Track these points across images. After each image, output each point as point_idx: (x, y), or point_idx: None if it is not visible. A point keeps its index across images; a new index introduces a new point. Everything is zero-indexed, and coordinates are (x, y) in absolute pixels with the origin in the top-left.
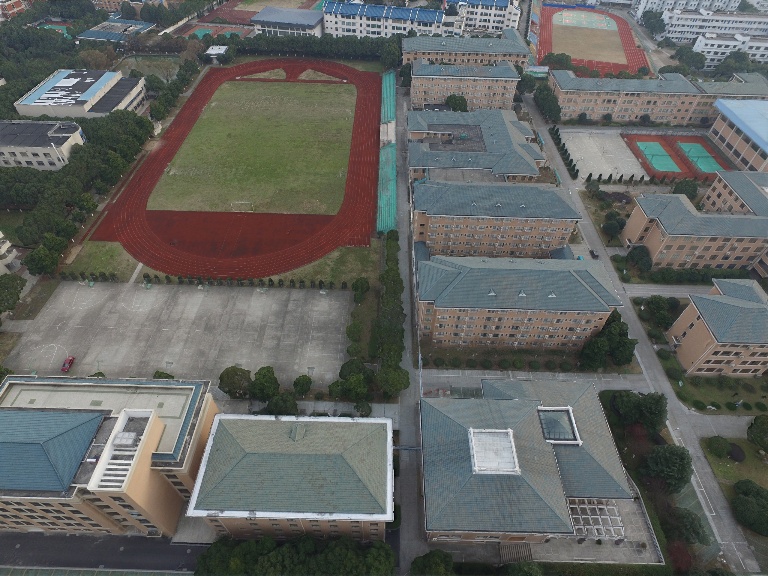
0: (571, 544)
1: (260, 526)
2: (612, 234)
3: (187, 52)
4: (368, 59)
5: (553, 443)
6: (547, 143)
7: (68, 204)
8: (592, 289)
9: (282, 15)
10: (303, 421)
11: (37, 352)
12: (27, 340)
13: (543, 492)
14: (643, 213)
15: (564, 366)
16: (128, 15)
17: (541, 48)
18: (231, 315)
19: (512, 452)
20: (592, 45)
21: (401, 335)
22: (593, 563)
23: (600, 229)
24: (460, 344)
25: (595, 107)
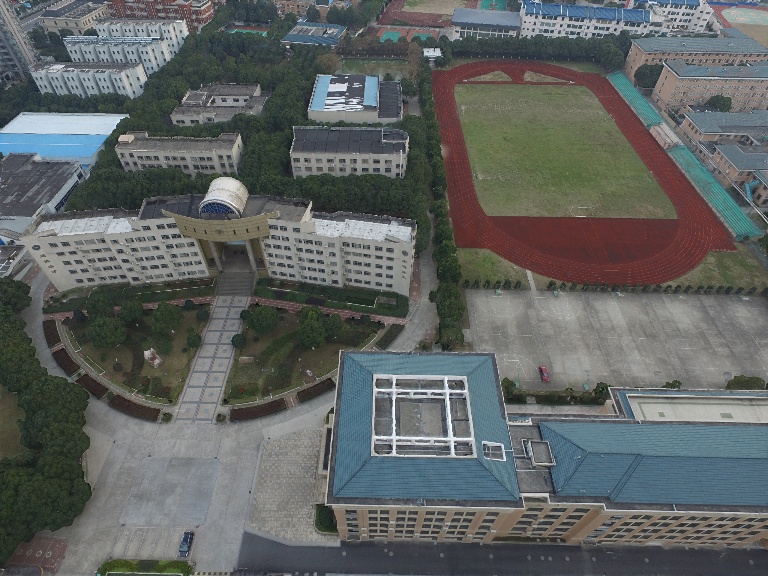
0: None
1: None
2: None
3: (414, 55)
4: (579, 60)
5: None
6: None
7: None
8: None
9: (482, 17)
10: None
11: (502, 362)
12: (481, 350)
13: None
14: None
15: None
16: (314, 18)
17: None
18: (661, 322)
19: None
20: None
21: None
22: None
23: None
24: None
25: None
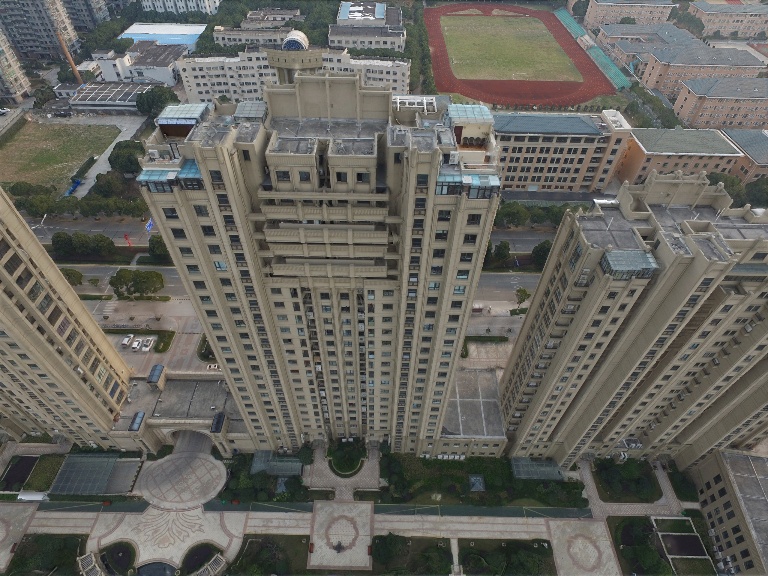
0: None
1: None
2: None
3: None
4: (535, 3)
5: None
6: None
7: None
8: None
9: None
10: None
11: None
12: None
13: None
14: None
15: None
16: None
17: None
18: None
19: None
20: None
21: None
22: None
23: None
24: None
25: (727, 26)
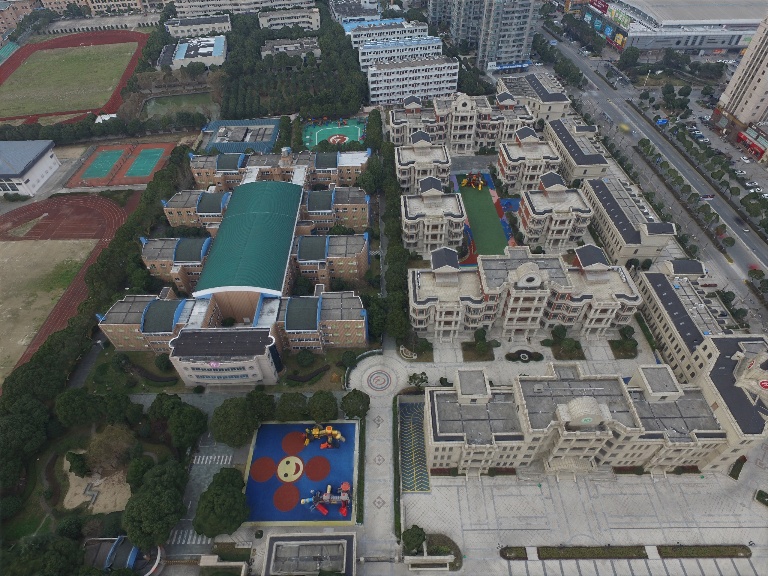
0: None
1: None
2: None
3: (131, 98)
4: None
5: None
6: None
7: None
8: None
9: (1, 147)
10: None
11: None
12: None
13: None
14: None
15: None
16: None
17: None
18: (93, 26)
19: None
20: None
21: None
22: None
23: None
24: None
25: None
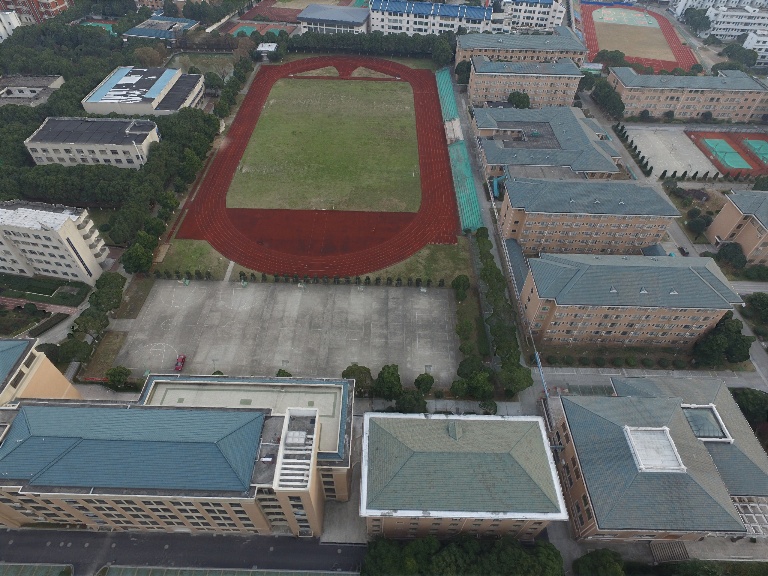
0: (725, 542)
1: (419, 525)
2: (699, 231)
3: (240, 49)
4: (418, 56)
5: (704, 441)
6: (613, 140)
7: (150, 202)
8: (712, 286)
9: (329, 12)
10: (454, 419)
11: (146, 351)
12: (134, 339)
13: (710, 490)
14: (738, 210)
15: (678, 363)
16: (170, 12)
17: (587, 45)
18: (333, 313)
19: (673, 450)
20: (637, 42)
21: (514, 333)
22: (753, 561)
23: (684, 226)
24: (570, 342)
25: (657, 104)
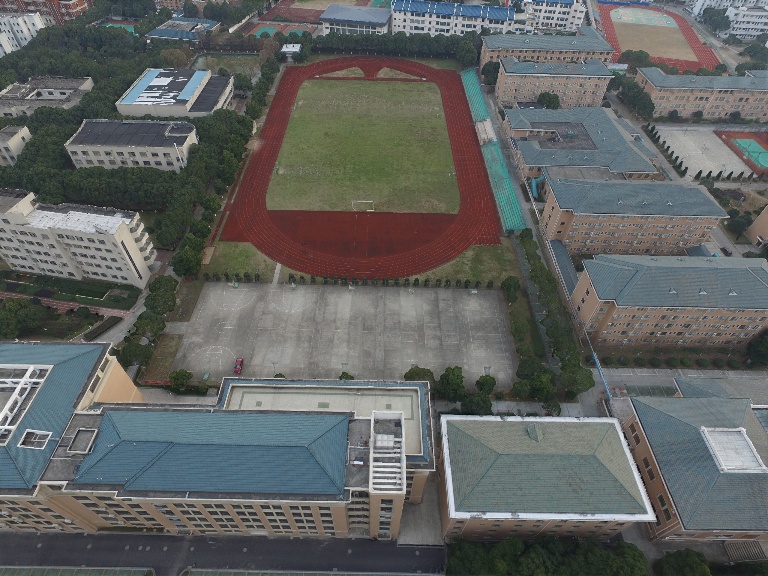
0: None
1: (500, 527)
2: (740, 231)
3: (265, 50)
4: (441, 57)
5: None
6: None
7: None
8: None
9: (351, 13)
10: (531, 421)
11: (203, 354)
12: (189, 342)
13: None
14: None
15: (733, 364)
16: (191, 13)
17: None
18: (385, 315)
19: (751, 451)
20: (658, 42)
21: None
22: None
23: (724, 226)
24: (624, 343)
25: (686, 104)
